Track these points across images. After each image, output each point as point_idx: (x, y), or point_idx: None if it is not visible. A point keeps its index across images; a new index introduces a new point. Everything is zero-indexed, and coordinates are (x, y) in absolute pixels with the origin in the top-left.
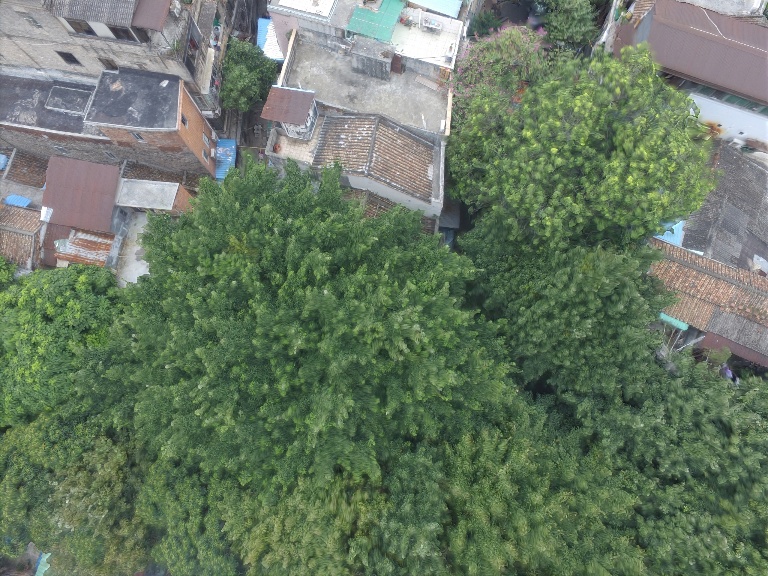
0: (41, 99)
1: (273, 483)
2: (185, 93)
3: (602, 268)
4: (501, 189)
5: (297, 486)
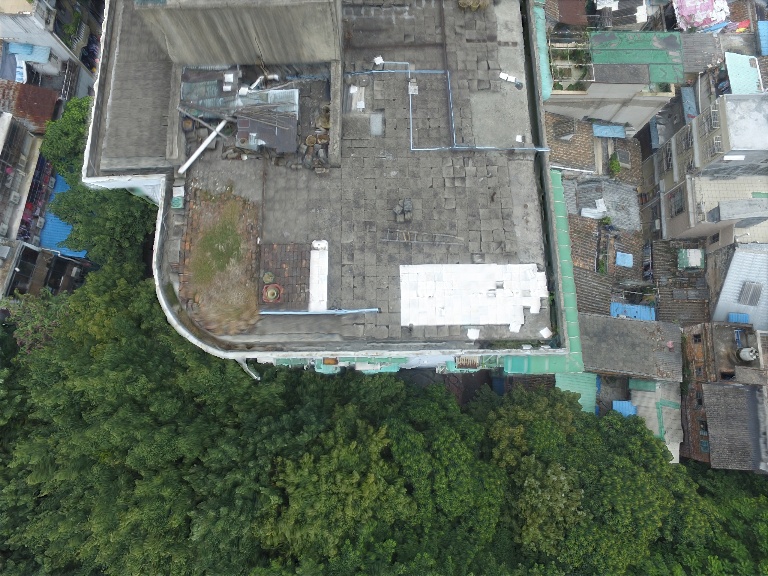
0: None
1: (361, 544)
2: None
3: None
4: None
5: None
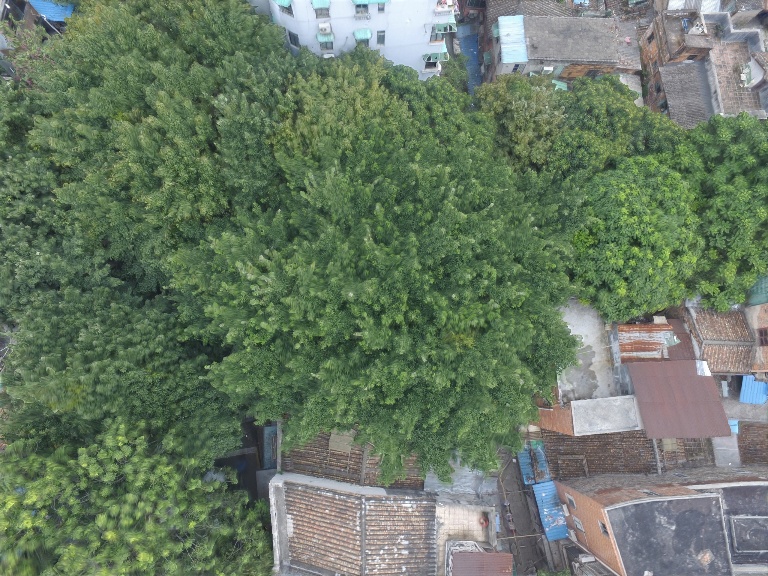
0: None
1: (373, 141)
2: (619, 572)
3: (54, 385)
4: (185, 489)
5: None
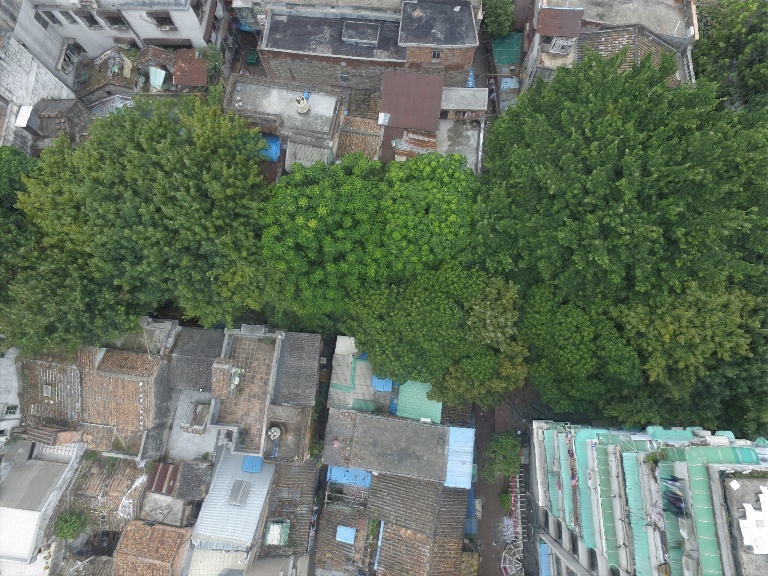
0: (331, 34)
1: (665, 289)
2: None
3: None
4: None
5: (688, 289)
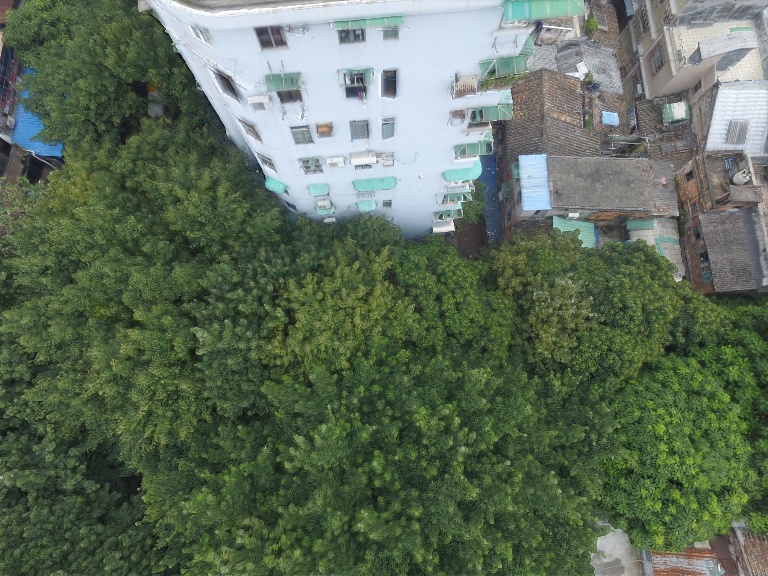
0: None
1: (374, 356)
2: None
3: None
4: None
5: None
